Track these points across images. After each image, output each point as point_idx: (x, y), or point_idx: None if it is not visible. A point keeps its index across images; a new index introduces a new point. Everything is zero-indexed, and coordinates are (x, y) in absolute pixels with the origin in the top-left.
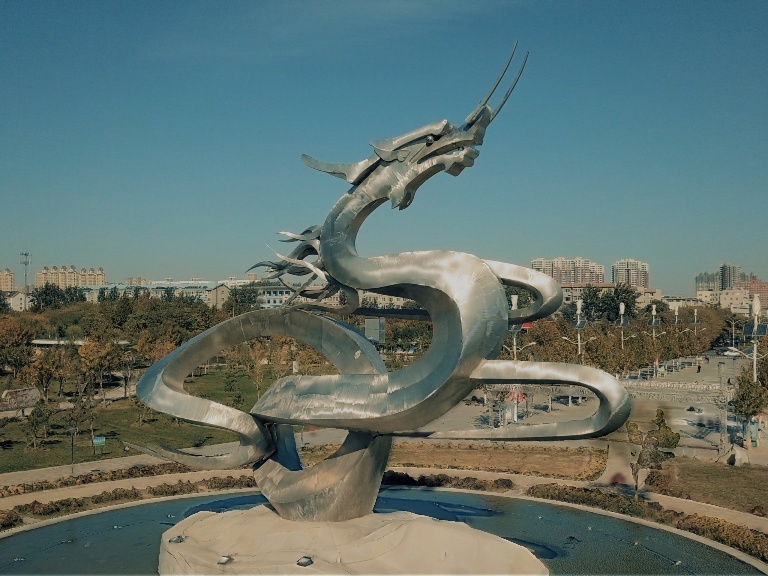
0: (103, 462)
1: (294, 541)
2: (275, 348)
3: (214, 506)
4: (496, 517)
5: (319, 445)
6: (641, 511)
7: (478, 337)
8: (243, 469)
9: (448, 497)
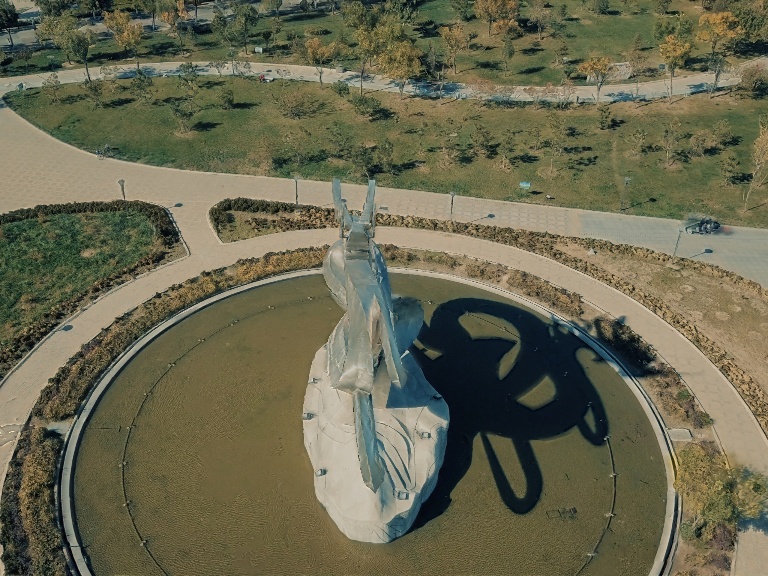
0: (515, 205)
1: (328, 398)
2: (764, 131)
3: (473, 305)
4: (594, 449)
5: (704, 262)
6: (686, 537)
7: (353, 375)
8: (572, 268)
9: (624, 401)
